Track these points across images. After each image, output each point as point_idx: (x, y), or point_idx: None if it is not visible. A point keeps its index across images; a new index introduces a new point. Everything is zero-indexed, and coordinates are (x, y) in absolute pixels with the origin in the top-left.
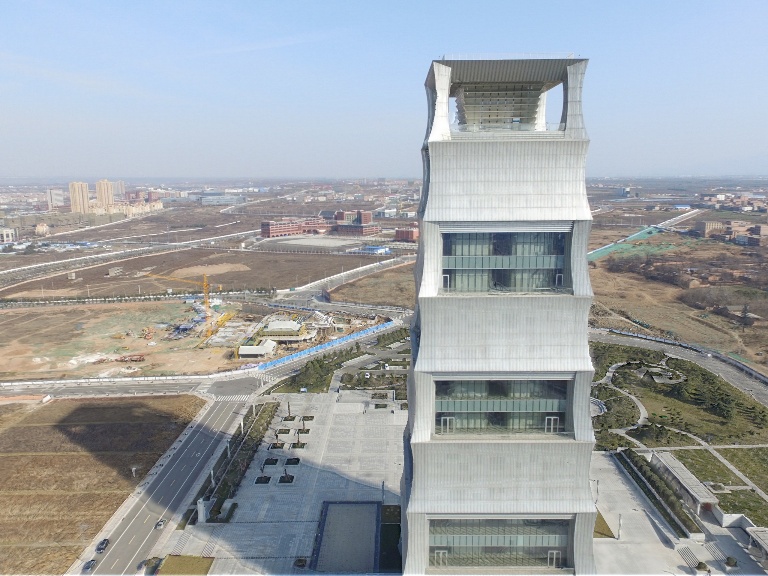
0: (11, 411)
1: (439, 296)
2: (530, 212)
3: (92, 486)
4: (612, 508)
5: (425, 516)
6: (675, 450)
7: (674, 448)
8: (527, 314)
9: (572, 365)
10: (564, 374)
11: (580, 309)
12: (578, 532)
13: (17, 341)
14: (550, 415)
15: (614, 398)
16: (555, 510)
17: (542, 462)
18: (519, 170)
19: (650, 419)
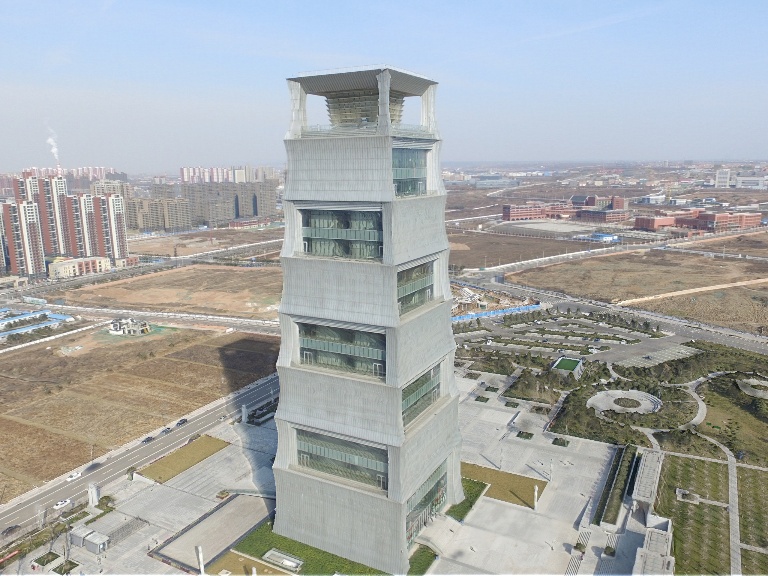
0: (204, 335)
1: (294, 257)
2: (349, 194)
3: (207, 388)
4: (561, 488)
5: (287, 423)
6: (688, 458)
7: (690, 456)
8: (350, 276)
9: (380, 321)
10: (379, 328)
11: (386, 275)
12: (391, 462)
13: (248, 290)
14: (376, 362)
15: (678, 401)
16: (370, 438)
17: (362, 397)
18: (343, 161)
19: (697, 427)
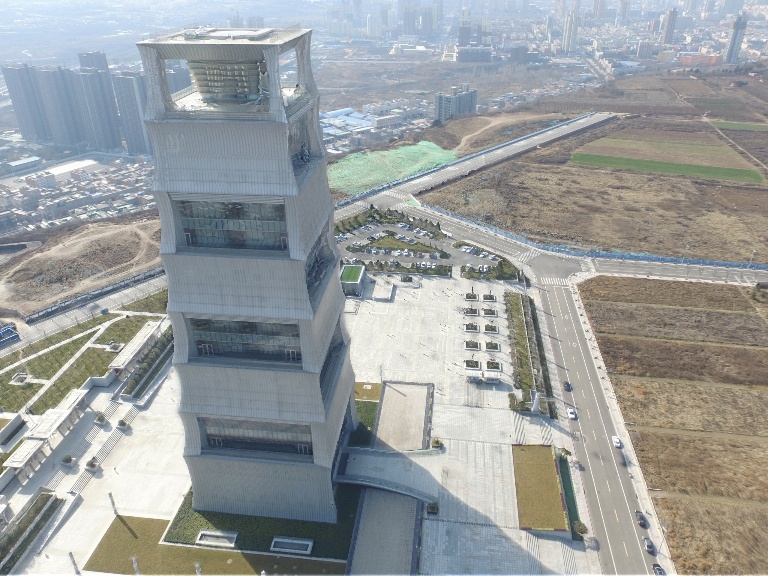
0: None
1: None
2: None
3: None
4: (70, 562)
5: None
6: None
7: None
8: None
9: None
10: None
11: None
12: None
13: None
14: None
15: None
16: None
17: None
18: None
19: None
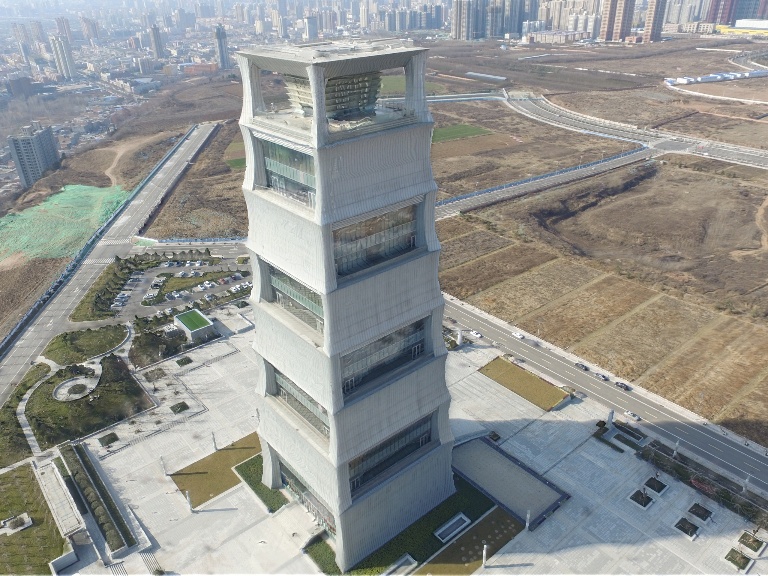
0: None
1: None
2: None
3: (742, 407)
4: None
5: None
6: None
7: None
8: None
9: None
10: None
11: None
12: None
13: None
14: None
15: None
16: None
17: None
18: None
19: None
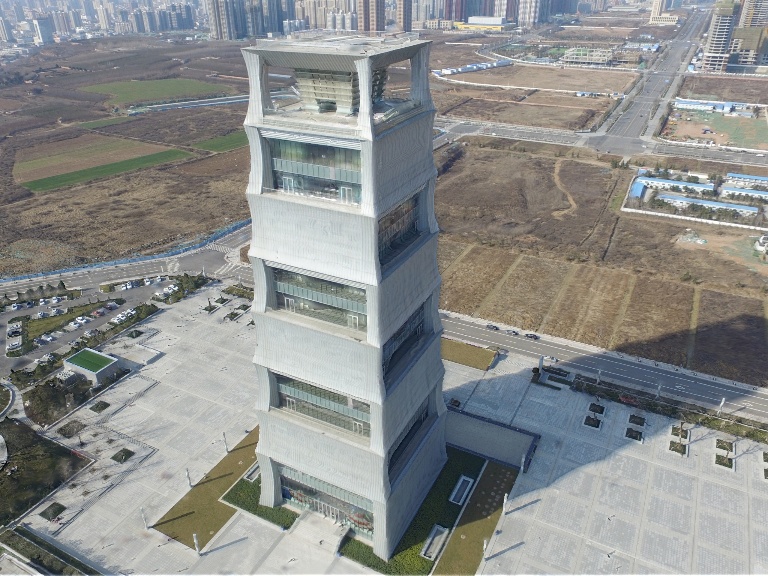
0: None
1: None
2: None
3: (623, 333)
4: None
5: None
6: None
7: None
8: None
9: None
10: None
11: None
12: None
13: None
14: None
15: None
16: None
17: None
18: None
19: None
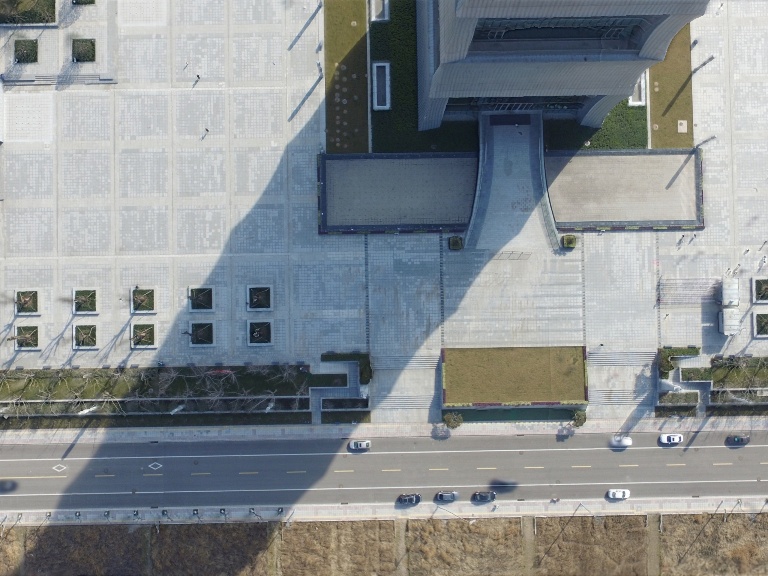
0: None
1: None
2: None
3: None
4: None
5: None
6: None
7: None
8: None
9: None
10: None
11: None
12: None
13: None
14: None
15: None
16: None
17: None
18: None
19: None
